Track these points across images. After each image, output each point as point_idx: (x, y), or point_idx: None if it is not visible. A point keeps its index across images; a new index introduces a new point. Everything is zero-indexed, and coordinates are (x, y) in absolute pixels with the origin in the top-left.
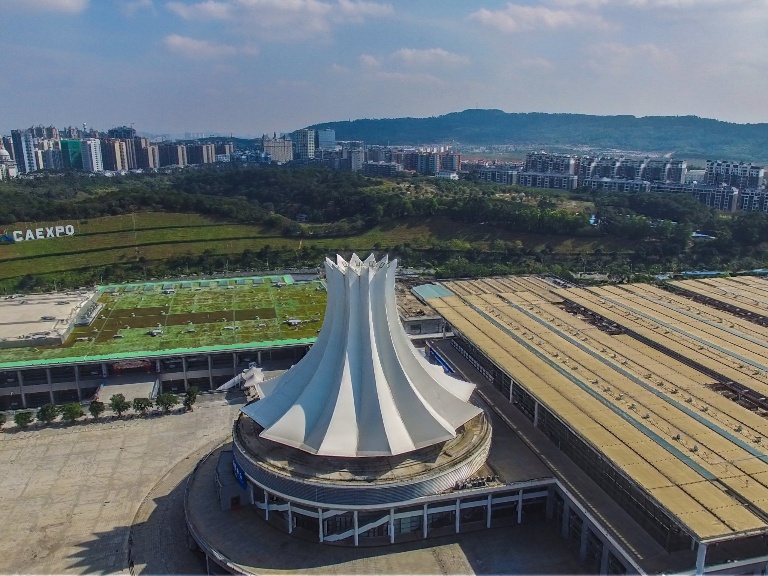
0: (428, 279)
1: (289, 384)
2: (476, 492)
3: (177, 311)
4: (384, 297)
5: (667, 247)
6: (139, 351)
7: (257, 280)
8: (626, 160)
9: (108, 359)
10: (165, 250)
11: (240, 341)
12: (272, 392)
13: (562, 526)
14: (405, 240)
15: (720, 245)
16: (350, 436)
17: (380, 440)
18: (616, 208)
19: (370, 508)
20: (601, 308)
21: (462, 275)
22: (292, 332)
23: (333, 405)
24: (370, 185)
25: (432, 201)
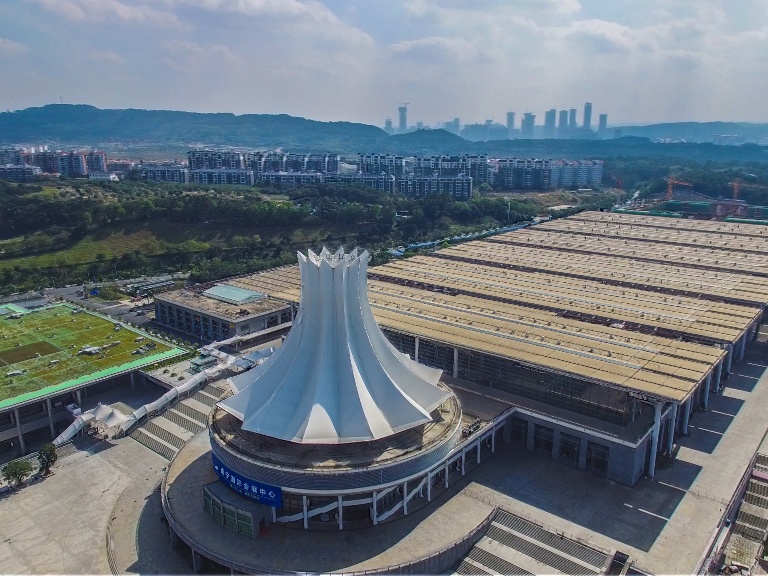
0: (184, 284)
1: (284, 389)
2: (479, 434)
3: None
4: None
5: (382, 227)
6: None
7: None
8: (291, 155)
9: None
10: None
11: (49, 383)
12: (248, 406)
13: (527, 442)
14: (128, 247)
15: (416, 222)
16: (379, 418)
17: (410, 412)
18: (331, 197)
19: (423, 473)
20: (420, 278)
21: (222, 274)
22: (103, 361)
23: (356, 394)
24: (29, 192)
25: (147, 203)
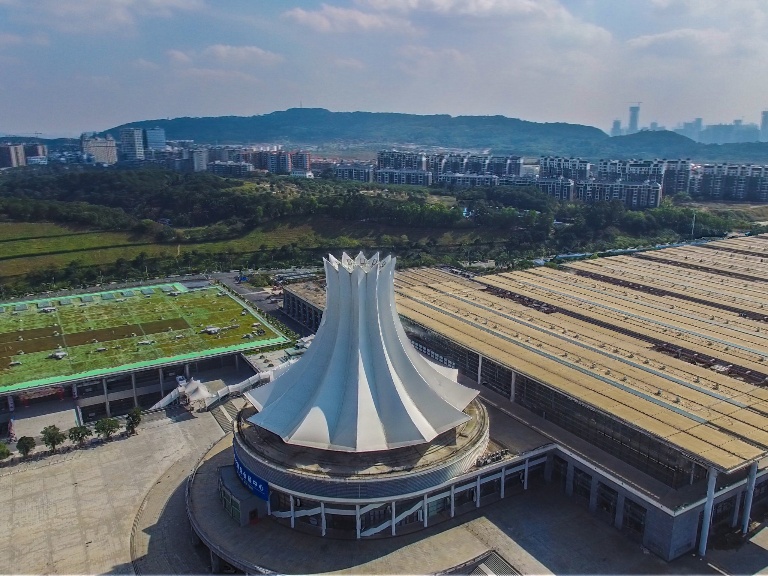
0: None
1: (295, 388)
2: (497, 466)
3: (72, 330)
4: (389, 292)
5: (535, 234)
6: (50, 377)
7: (146, 290)
8: (472, 157)
9: (17, 390)
10: (20, 265)
11: (164, 355)
12: (268, 399)
13: (566, 485)
14: (290, 240)
15: (577, 230)
16: (376, 430)
17: (409, 430)
18: (487, 201)
19: (411, 496)
20: (524, 291)
21: None
22: (216, 340)
23: (355, 402)
24: (231, 186)
25: (312, 200)
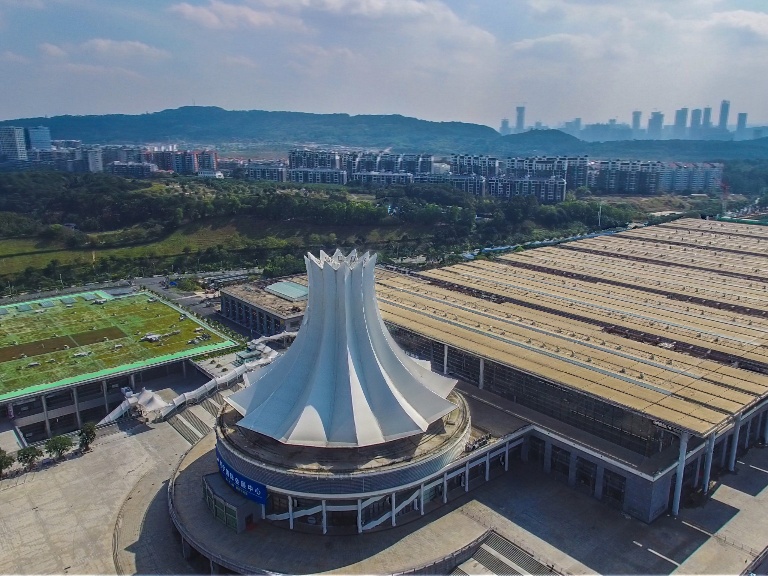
0: (257, 279)
1: (282, 389)
2: (484, 450)
3: None
4: (372, 288)
5: (459, 229)
6: None
7: (66, 300)
8: (385, 155)
9: None
10: None
11: (106, 366)
12: (252, 402)
13: (544, 463)
14: (214, 242)
15: (497, 225)
16: (371, 425)
17: (404, 421)
18: (410, 198)
19: (411, 486)
20: (471, 283)
21: (293, 271)
22: (160, 348)
23: (349, 398)
24: (139, 187)
25: (234, 200)
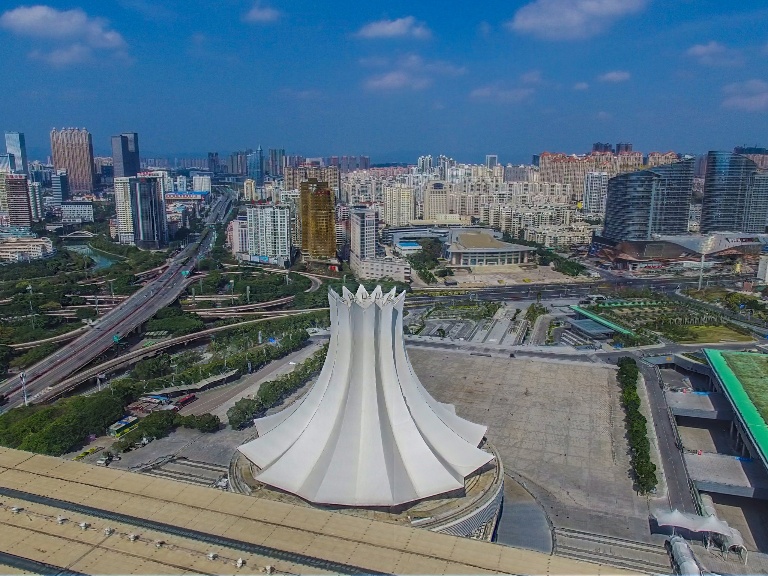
0: None
1: None
2: None
3: None
4: None
5: None
6: None
7: None
8: None
9: (752, 434)
10: None
11: None
12: None
13: None
14: None
15: None
16: None
17: None
18: None
19: None
20: None
21: None
22: None
23: None
24: None
25: None
